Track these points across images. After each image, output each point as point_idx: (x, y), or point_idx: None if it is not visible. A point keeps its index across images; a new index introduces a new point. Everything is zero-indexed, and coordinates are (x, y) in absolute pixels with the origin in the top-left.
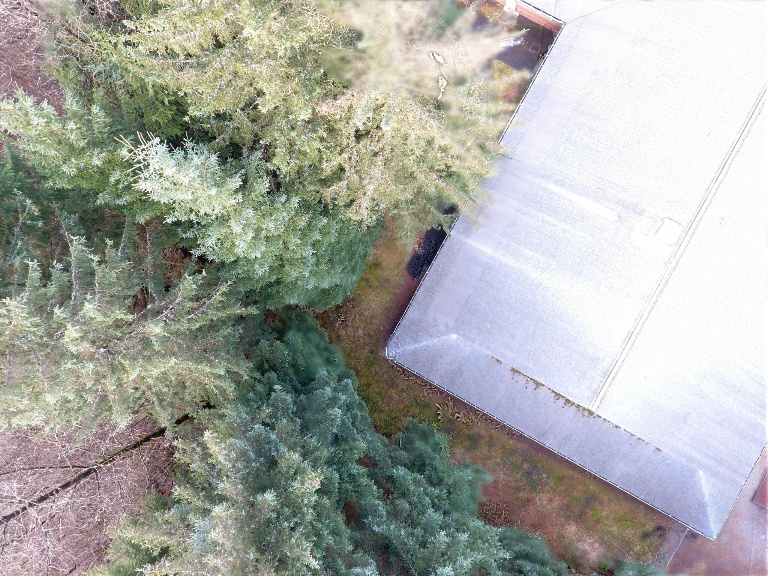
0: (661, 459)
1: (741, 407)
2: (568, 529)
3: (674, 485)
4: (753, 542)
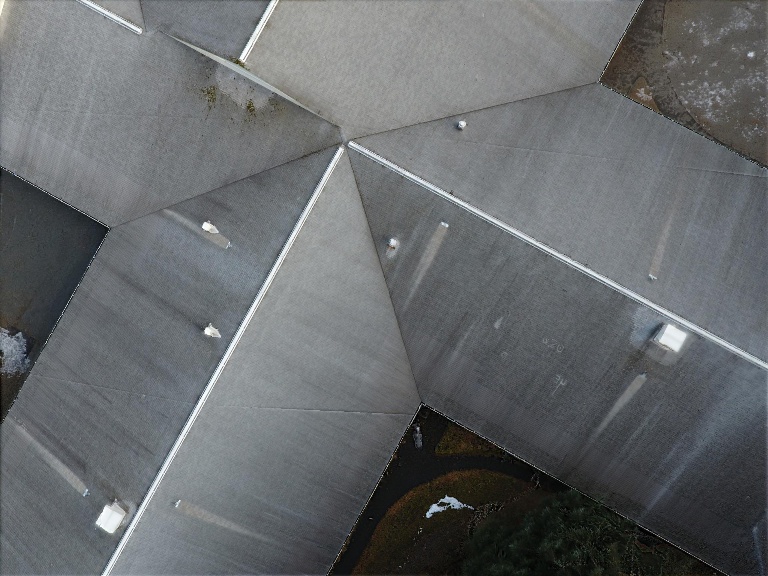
0: None
1: None
2: None
3: None
4: None
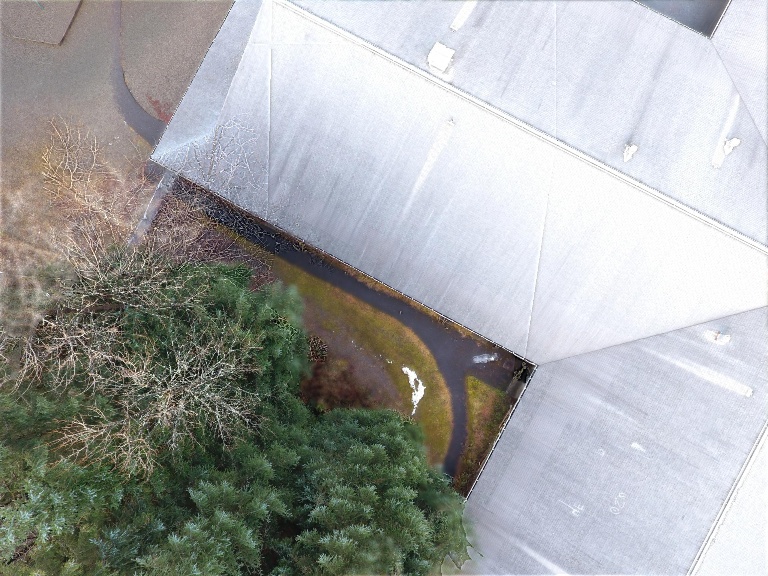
0: None
1: None
2: None
3: None
4: None
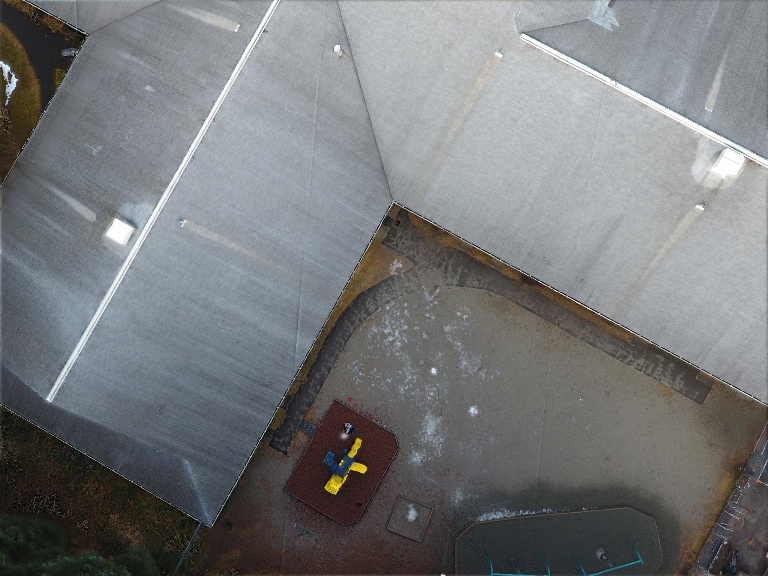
0: (152, 449)
1: (227, 399)
2: (111, 518)
3: (167, 474)
4: (285, 530)
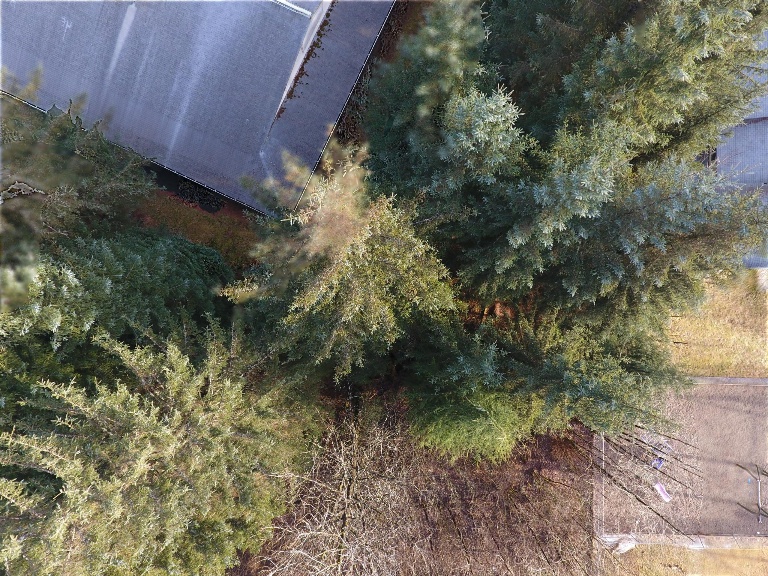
0: None
1: None
2: (451, 47)
3: None
4: None
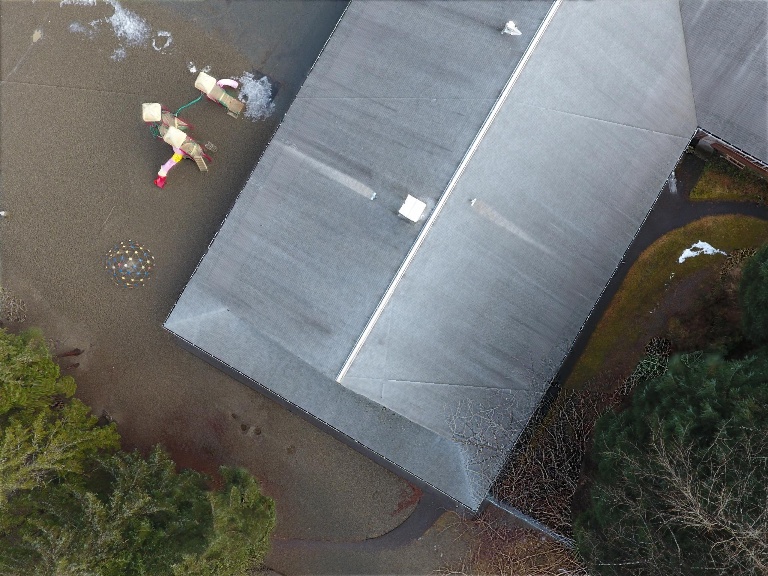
0: None
1: None
2: None
3: None
4: None
